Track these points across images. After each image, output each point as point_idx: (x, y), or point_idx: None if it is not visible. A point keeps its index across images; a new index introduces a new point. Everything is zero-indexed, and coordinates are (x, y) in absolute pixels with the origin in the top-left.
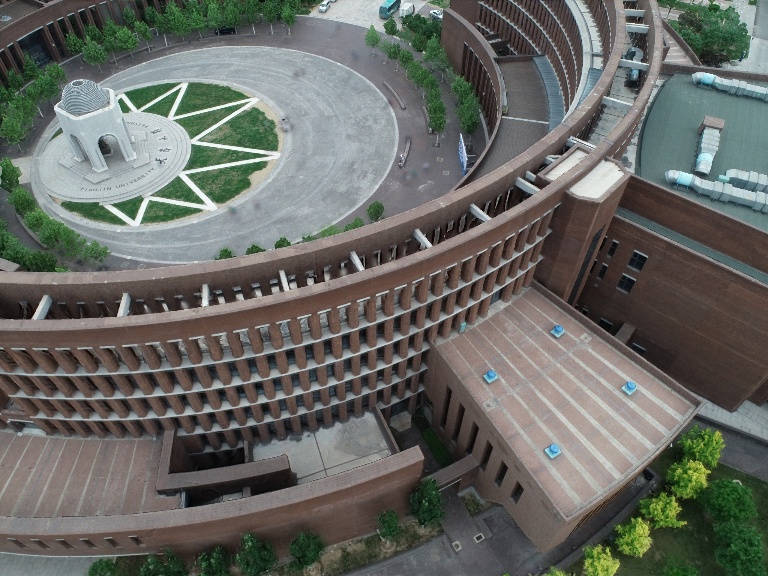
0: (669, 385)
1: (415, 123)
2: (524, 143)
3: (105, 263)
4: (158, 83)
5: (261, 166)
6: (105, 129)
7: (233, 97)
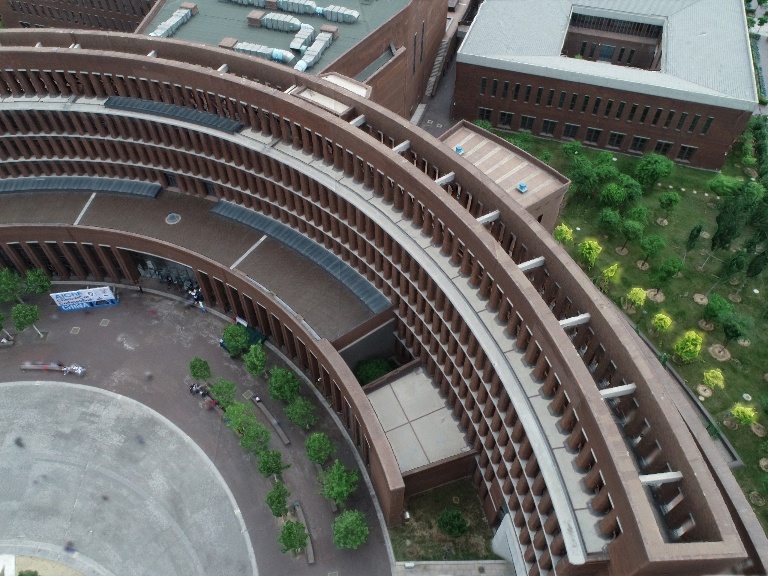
0: (450, 135)
1: None
2: (130, 213)
3: None
4: None
5: None
6: None
7: None
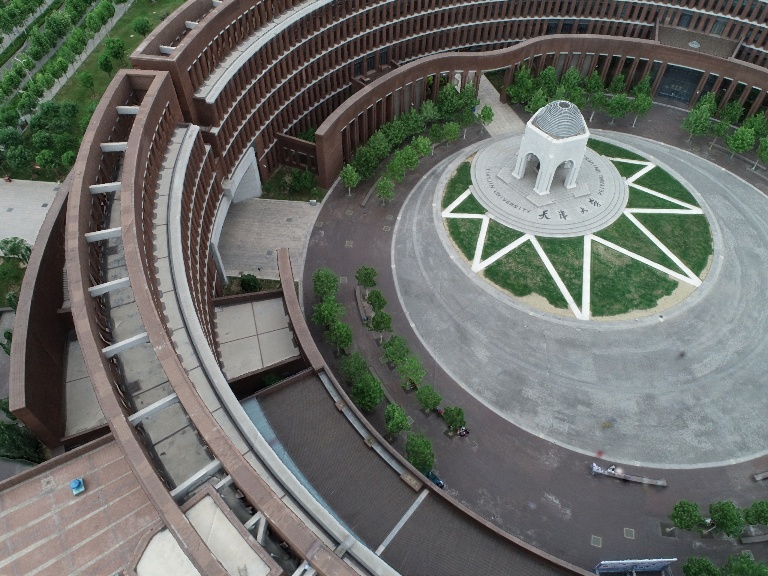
0: None
1: (720, 497)
2: None
3: (391, 204)
4: (689, 188)
5: (557, 302)
6: (538, 151)
7: (692, 259)
